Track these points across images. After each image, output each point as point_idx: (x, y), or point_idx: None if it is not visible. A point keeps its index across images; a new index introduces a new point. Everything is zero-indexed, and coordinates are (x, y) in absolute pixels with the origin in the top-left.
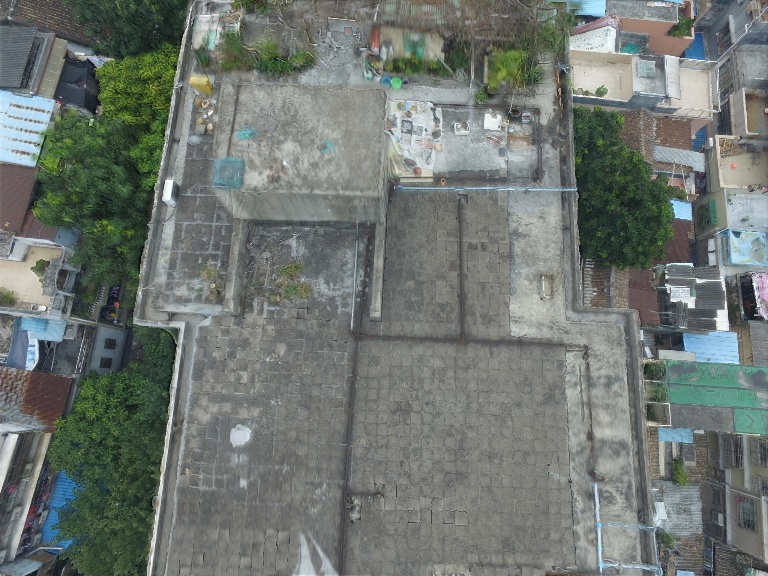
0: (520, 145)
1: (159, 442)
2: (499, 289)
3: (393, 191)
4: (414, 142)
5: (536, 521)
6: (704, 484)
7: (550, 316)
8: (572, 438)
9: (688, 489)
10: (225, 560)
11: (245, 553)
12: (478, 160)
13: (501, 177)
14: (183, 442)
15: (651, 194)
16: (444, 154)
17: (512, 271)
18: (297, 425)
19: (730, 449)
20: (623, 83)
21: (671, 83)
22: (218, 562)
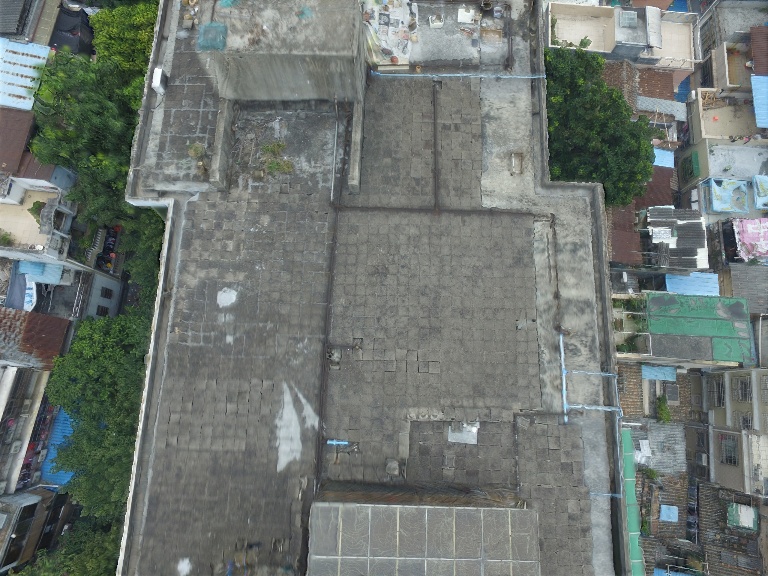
0: (492, 37)
1: None
2: (471, 165)
3: (371, 75)
4: (391, 33)
5: (505, 370)
6: (689, 429)
7: (520, 190)
8: (540, 298)
9: (672, 429)
10: (212, 407)
11: (231, 400)
12: (452, 50)
13: (474, 65)
14: (173, 305)
15: (631, 133)
16: (420, 45)
17: (484, 150)
18: (280, 287)
19: (713, 390)
20: (606, 35)
21: (652, 33)
22: (206, 409)
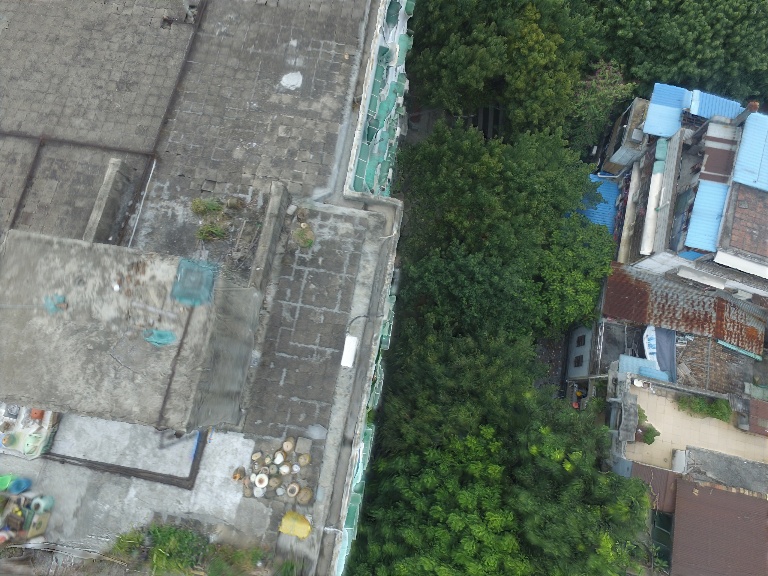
0: None
1: (502, 237)
2: None
3: None
4: None
5: None
6: None
7: None
8: None
9: None
10: None
11: None
12: None
13: None
14: (352, 84)
15: None
16: None
17: None
18: (234, 83)
19: None
20: None
21: None
22: None
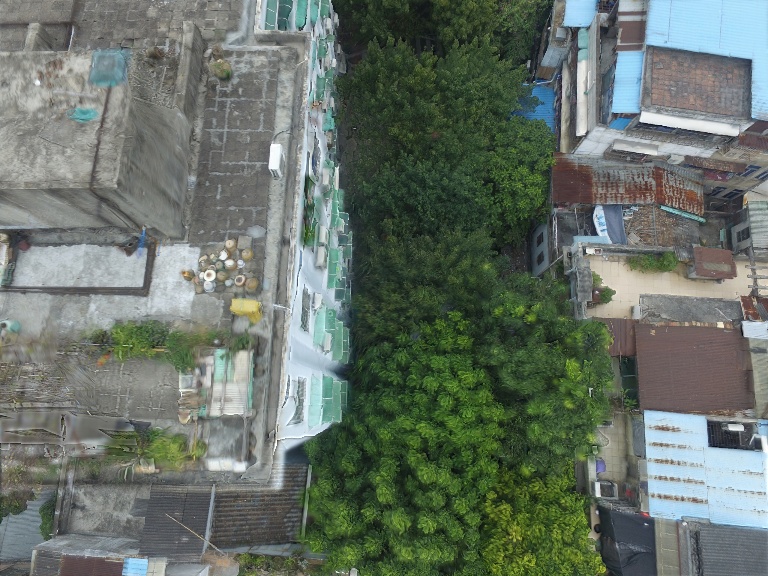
0: None
1: (447, 144)
2: None
3: None
4: None
5: None
6: None
7: None
8: None
9: None
10: None
11: None
12: None
13: None
14: None
15: None
16: None
17: None
18: None
19: None
20: None
21: None
22: None
